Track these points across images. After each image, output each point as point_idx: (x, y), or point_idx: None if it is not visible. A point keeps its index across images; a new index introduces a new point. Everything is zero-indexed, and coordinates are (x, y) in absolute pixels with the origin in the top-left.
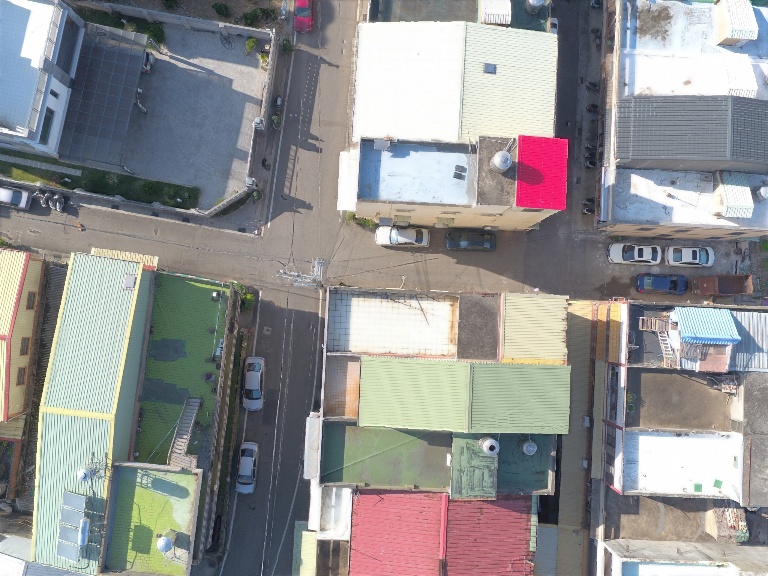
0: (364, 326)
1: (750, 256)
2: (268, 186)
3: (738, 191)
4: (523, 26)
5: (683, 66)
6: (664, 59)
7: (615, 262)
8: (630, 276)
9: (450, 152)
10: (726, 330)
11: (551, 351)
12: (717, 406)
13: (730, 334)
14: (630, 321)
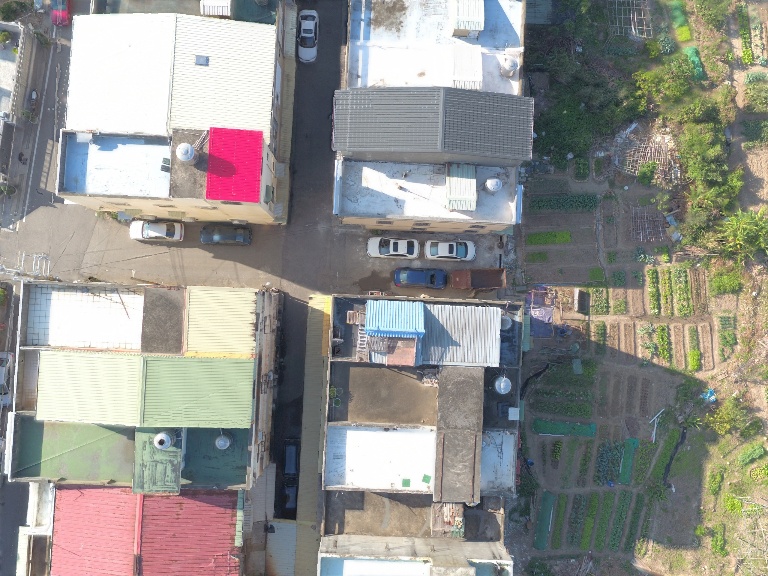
0: (64, 320)
1: (515, 250)
2: (24, 180)
3: (463, 183)
4: (253, 18)
5: (418, 58)
6: (398, 51)
7: (373, 256)
8: (390, 270)
9: (158, 145)
10: (412, 323)
11: (238, 345)
12: (427, 400)
13: (415, 327)
14: (339, 315)
